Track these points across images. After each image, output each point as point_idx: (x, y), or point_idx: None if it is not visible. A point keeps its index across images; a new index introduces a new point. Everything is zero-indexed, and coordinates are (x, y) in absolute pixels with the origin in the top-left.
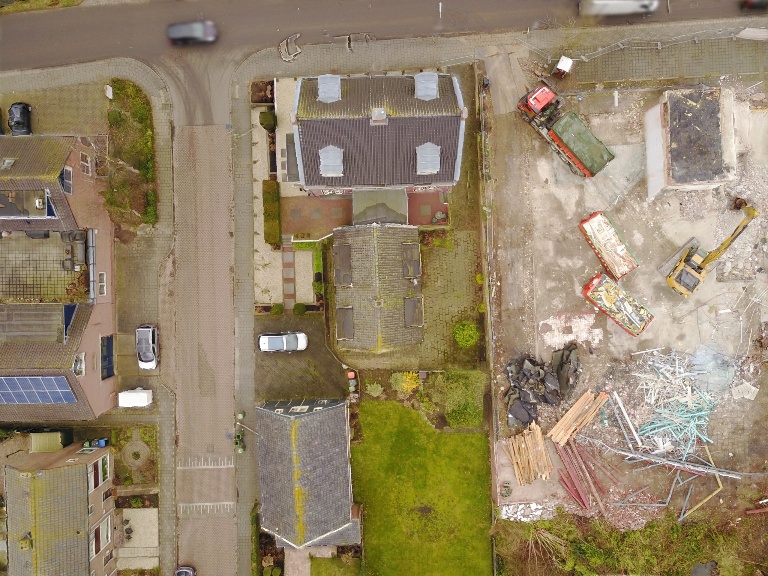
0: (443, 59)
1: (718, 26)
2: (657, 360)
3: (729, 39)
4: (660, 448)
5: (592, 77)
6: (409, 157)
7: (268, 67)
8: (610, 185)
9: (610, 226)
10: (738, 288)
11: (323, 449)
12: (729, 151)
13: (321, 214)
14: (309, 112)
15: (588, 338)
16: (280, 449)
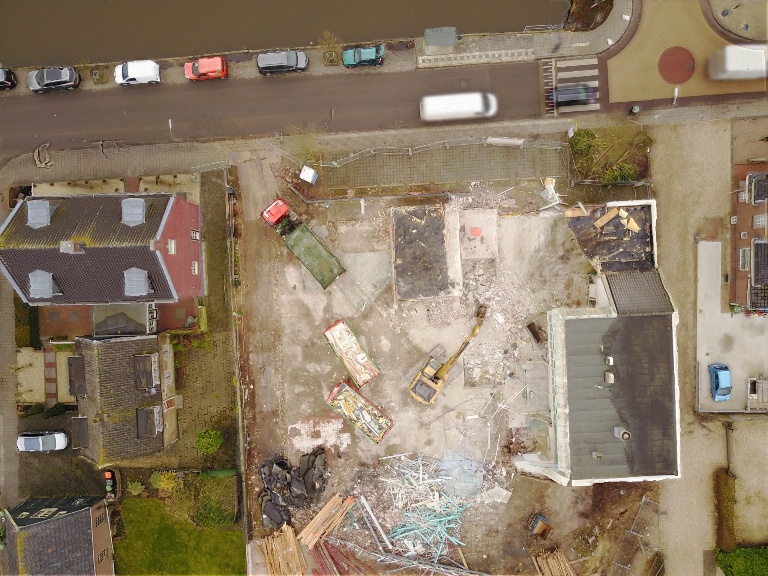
0: (197, 164)
1: (469, 132)
2: (403, 465)
3: (480, 145)
4: (411, 551)
5: (344, 182)
6: (121, 279)
7: (26, 172)
8: (357, 291)
9: (351, 335)
10: (486, 394)
11: (59, 555)
12: (454, 267)
13: (79, 317)
14: (10, 240)
15: (336, 442)
16: (14, 556)
